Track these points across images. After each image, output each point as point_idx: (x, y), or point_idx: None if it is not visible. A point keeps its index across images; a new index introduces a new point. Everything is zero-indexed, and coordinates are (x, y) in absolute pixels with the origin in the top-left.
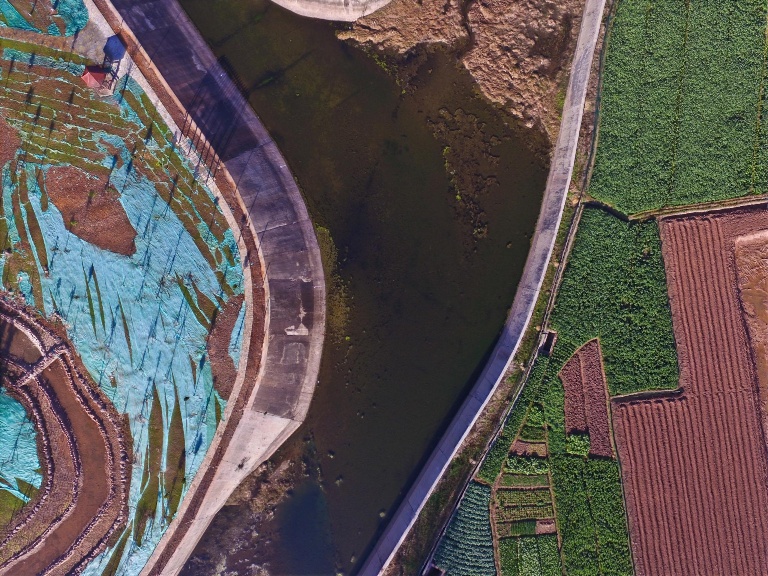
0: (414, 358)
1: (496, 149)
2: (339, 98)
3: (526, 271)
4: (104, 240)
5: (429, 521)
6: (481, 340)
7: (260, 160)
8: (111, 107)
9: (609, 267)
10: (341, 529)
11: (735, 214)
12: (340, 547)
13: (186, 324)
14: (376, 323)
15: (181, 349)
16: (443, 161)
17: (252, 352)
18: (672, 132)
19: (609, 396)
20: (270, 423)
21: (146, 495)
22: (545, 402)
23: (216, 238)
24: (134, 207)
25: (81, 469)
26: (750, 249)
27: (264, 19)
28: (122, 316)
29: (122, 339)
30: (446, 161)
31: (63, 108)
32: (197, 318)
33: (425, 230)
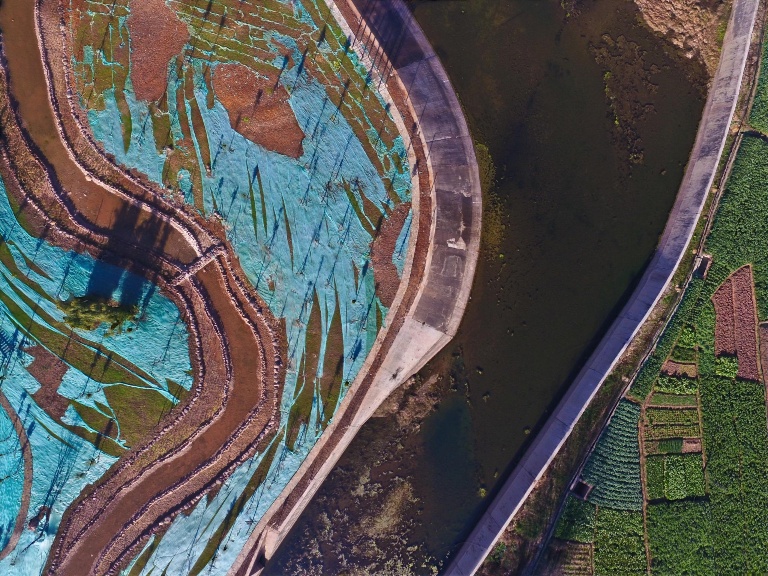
0: (565, 279)
1: (655, 77)
2: (504, 17)
3: (680, 198)
4: (271, 141)
5: (581, 436)
6: (631, 264)
7: (427, 72)
8: (284, 7)
9: (766, 195)
10: (485, 445)
11: None
12: (484, 463)
13: (351, 229)
14: (530, 242)
15: (344, 254)
16: (603, 86)
17: (416, 260)
18: None
19: (758, 321)
20: (426, 334)
21: (300, 400)
22: (698, 324)
23: (385, 145)
24: (303, 109)
25: (232, 373)
26: None
27: None
28: (285, 219)
29: (284, 242)
30: (606, 86)
31: (235, 5)
32: (362, 224)
33: (582, 153)
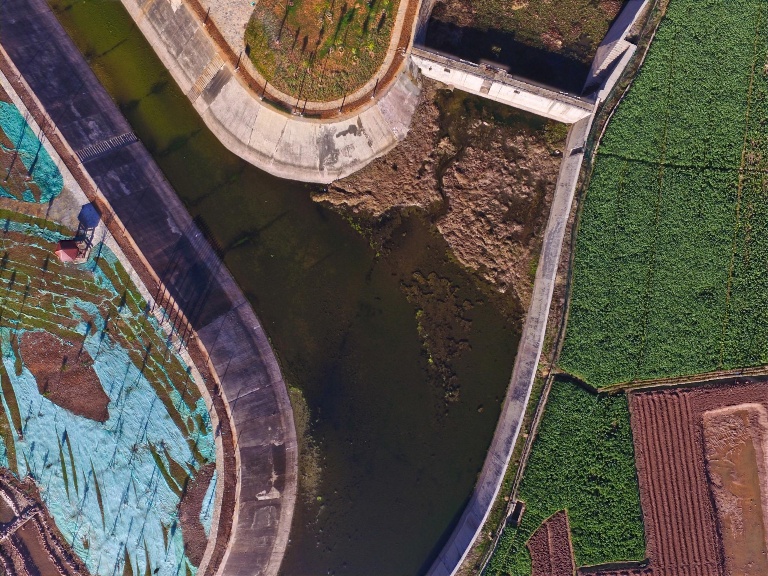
0: (385, 518)
1: (469, 313)
2: (313, 259)
3: (496, 436)
4: (77, 406)
5: None
6: (451, 502)
7: (234, 324)
8: (85, 274)
9: (577, 440)
10: None
11: (703, 389)
12: None
13: (158, 491)
14: (347, 483)
15: (153, 515)
16: (416, 324)
17: (223, 520)
18: (642, 307)
19: (576, 566)
20: None
21: None
22: (512, 571)
23: (188, 406)
24: (107, 374)
25: None
26: (718, 420)
27: (240, 179)
28: (95, 481)
29: (95, 503)
30: (419, 324)
31: (37, 274)
32: (169, 485)
33: (397, 392)
